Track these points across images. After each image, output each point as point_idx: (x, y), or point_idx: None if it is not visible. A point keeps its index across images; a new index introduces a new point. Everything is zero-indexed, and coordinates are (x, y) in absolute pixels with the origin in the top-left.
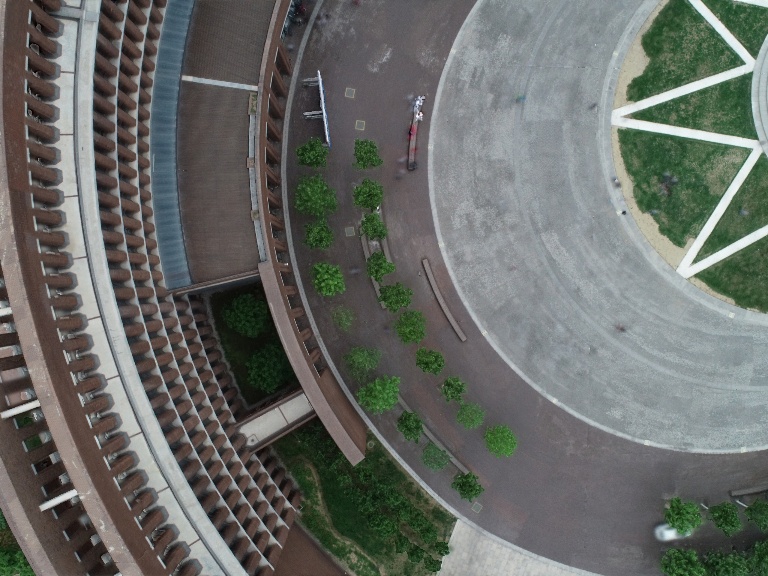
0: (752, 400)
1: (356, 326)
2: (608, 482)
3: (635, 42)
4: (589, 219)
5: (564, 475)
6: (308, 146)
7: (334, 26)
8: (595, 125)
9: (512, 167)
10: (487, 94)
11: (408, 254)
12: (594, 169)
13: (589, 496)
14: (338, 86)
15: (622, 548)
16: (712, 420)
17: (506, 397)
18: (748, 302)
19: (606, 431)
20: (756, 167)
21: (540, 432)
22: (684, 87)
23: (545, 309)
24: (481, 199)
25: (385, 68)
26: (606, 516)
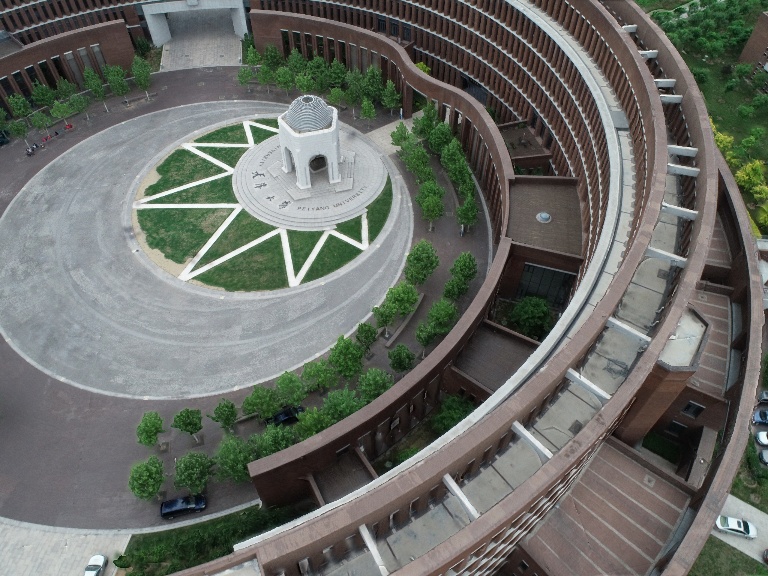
0: (242, 350)
1: None
2: (105, 437)
3: (152, 170)
4: (110, 258)
5: (62, 439)
6: None
7: None
8: (120, 210)
9: (54, 238)
10: (43, 205)
11: None
12: (117, 231)
13: (84, 453)
14: None
15: (114, 497)
16: (207, 370)
17: (17, 384)
18: (235, 288)
19: (108, 395)
20: (238, 216)
21: (44, 406)
22: (185, 186)
23: (65, 316)
24: (26, 258)
25: None
26: (100, 469)
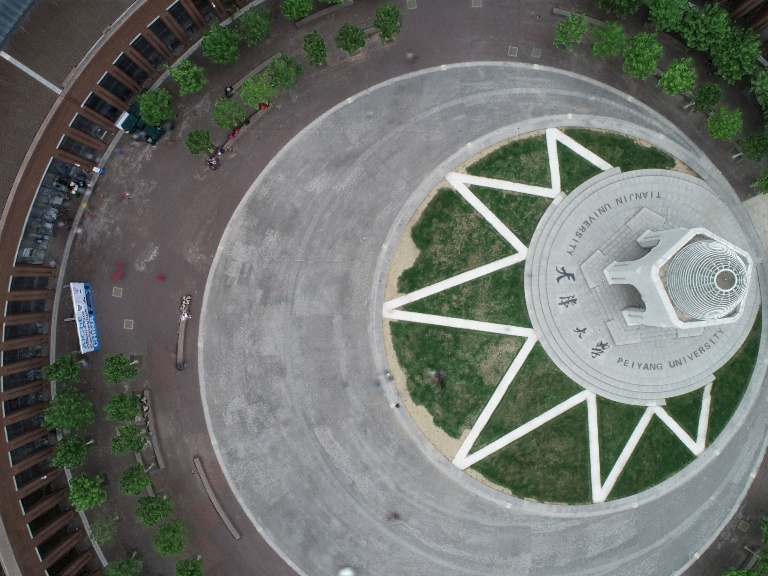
0: None
1: (130, 525)
2: None
3: (404, 234)
4: (362, 413)
5: None
6: (53, 367)
7: (99, 226)
8: (366, 318)
9: (283, 362)
10: (256, 290)
11: (180, 452)
12: (366, 362)
13: None
14: (105, 285)
15: None
16: None
17: None
18: (525, 492)
19: None
20: (531, 356)
21: None
22: (456, 277)
23: (320, 504)
24: (253, 395)
25: (152, 266)
26: None
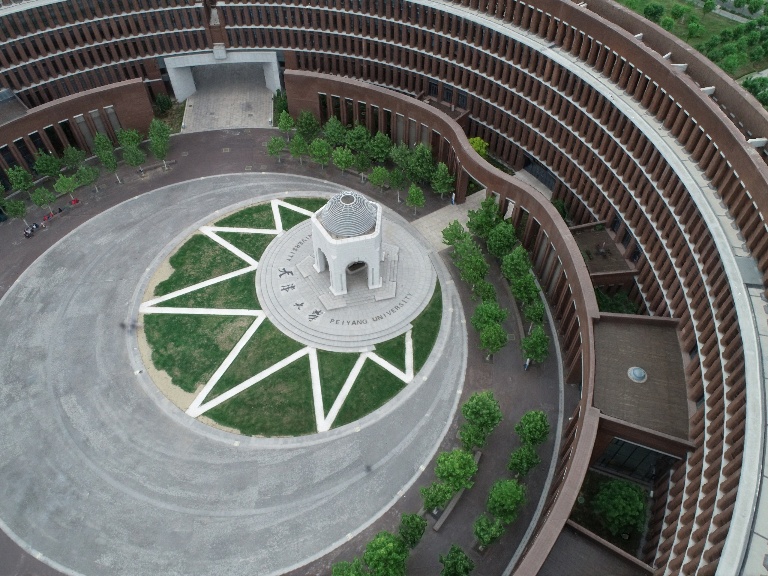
0: (257, 524)
1: None
2: None
3: (164, 261)
4: (108, 381)
5: None
6: None
7: None
8: (125, 314)
9: (46, 350)
10: (38, 304)
11: None
12: (119, 344)
13: None
14: None
15: None
16: (213, 552)
17: None
18: (253, 430)
19: None
20: (260, 327)
21: None
22: (202, 283)
23: (50, 462)
24: (11, 377)
25: None
26: None
